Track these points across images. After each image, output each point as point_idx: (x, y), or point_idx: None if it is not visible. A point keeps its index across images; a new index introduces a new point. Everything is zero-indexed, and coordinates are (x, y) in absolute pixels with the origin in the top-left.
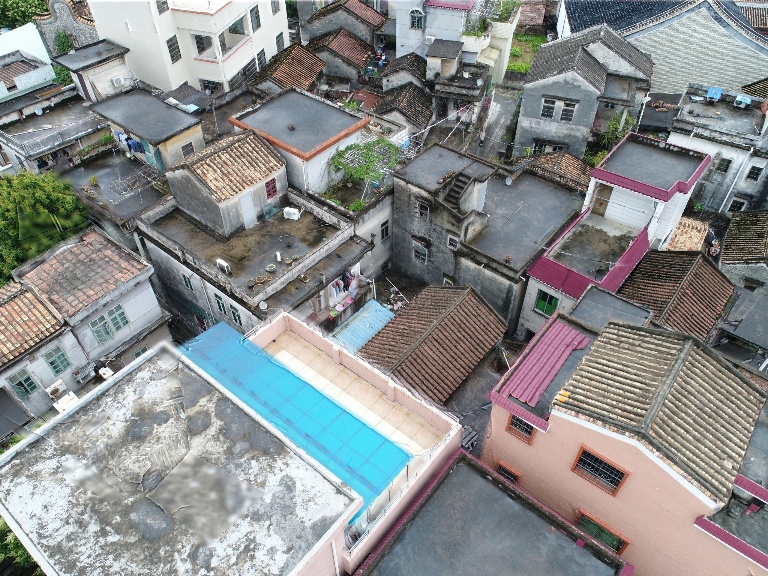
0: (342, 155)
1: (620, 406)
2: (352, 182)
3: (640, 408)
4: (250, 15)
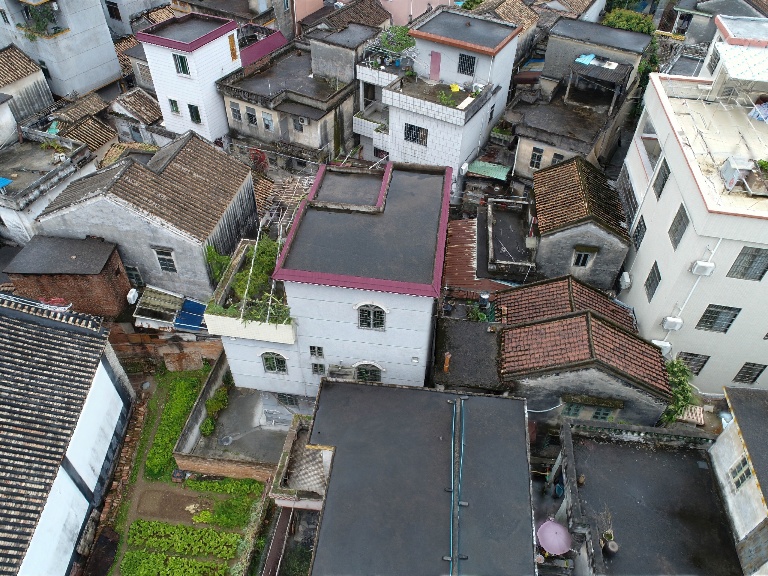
0: None
1: None
2: None
3: None
4: None
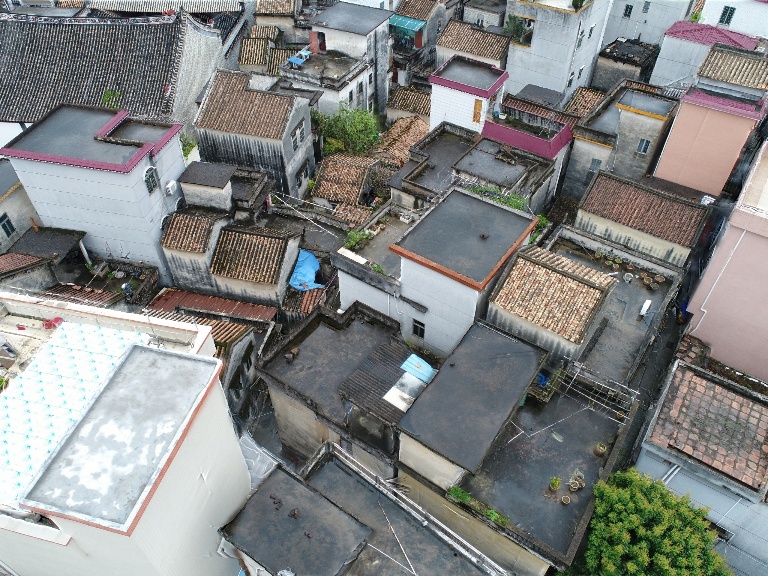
0: None
1: (764, 69)
2: None
3: (763, 63)
4: None
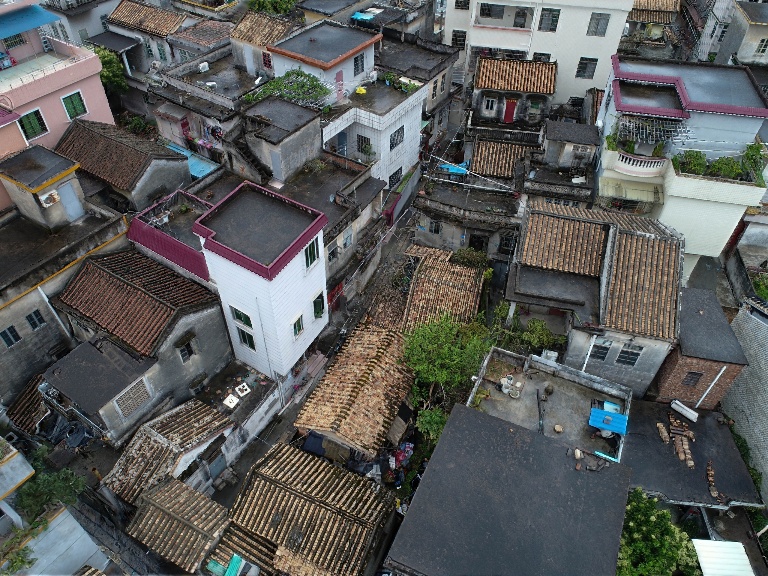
0: (300, 74)
1: None
2: None
3: None
4: (542, 12)
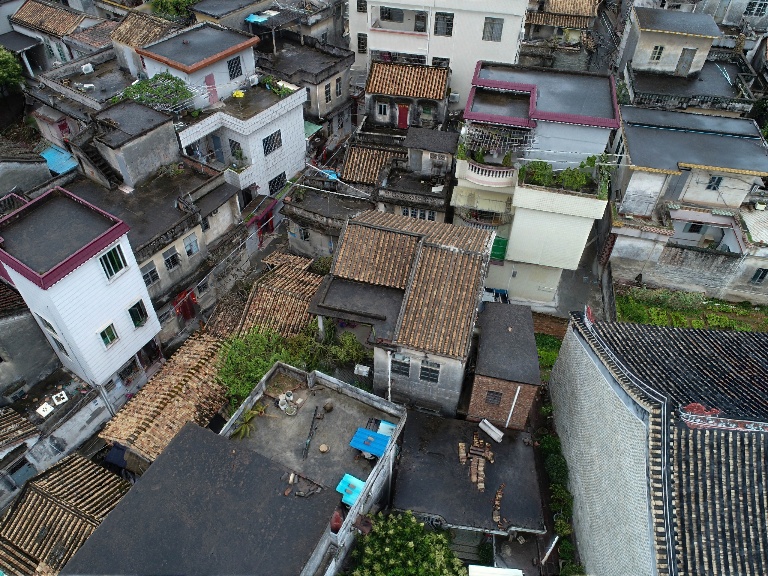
0: (167, 77)
1: None
2: (173, 107)
3: None
4: (436, 16)
